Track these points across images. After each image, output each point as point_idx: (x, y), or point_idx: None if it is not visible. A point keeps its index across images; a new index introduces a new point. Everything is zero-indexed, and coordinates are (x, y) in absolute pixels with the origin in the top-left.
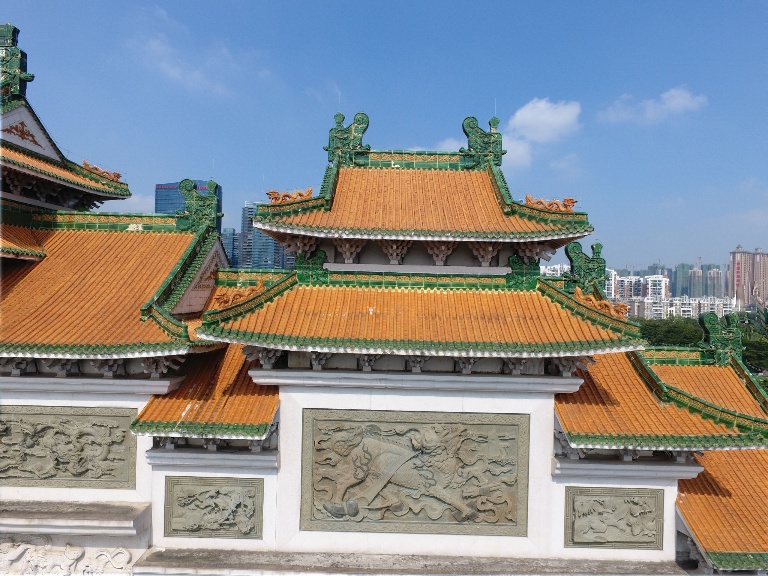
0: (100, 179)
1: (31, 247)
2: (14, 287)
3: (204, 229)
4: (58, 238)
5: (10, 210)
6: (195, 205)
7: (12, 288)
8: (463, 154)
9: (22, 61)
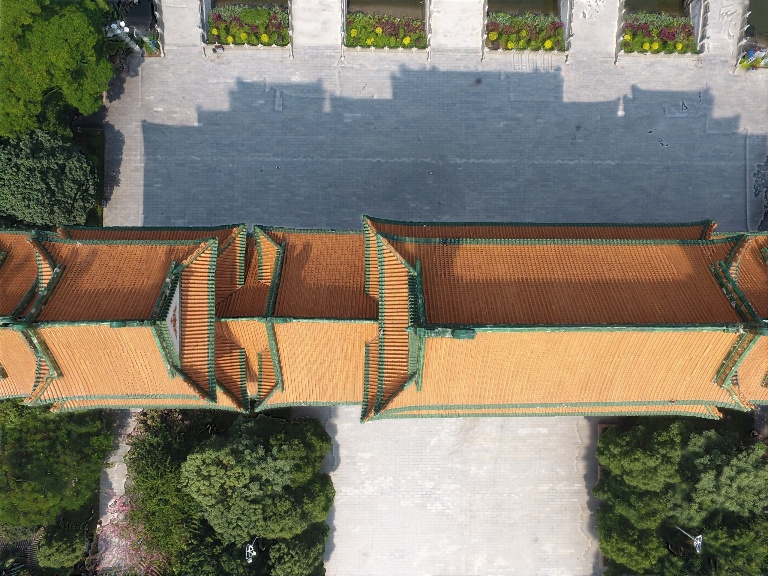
0: None
1: None
2: None
3: None
4: None
5: None
6: None
7: None
8: None
9: None
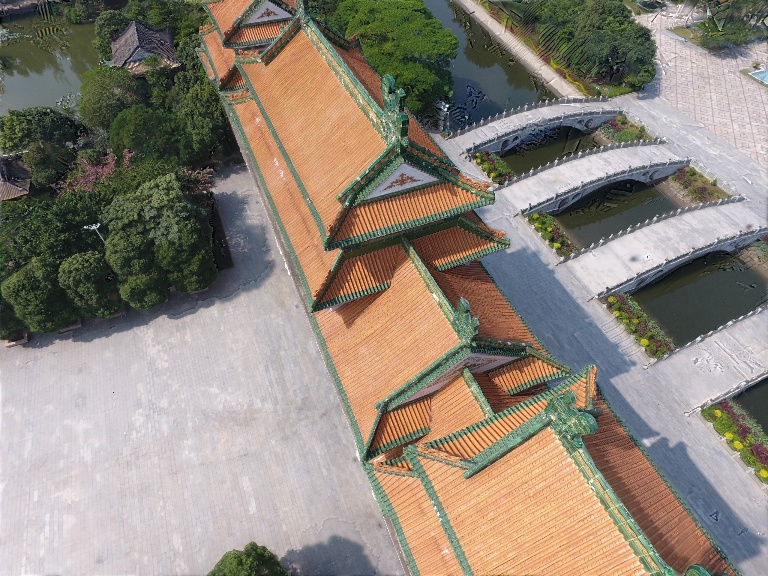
0: (471, 188)
1: (386, 276)
2: (365, 309)
3: (456, 349)
4: (405, 268)
5: (385, 241)
6: (462, 323)
7: (364, 309)
8: (663, 575)
9: (403, 128)
